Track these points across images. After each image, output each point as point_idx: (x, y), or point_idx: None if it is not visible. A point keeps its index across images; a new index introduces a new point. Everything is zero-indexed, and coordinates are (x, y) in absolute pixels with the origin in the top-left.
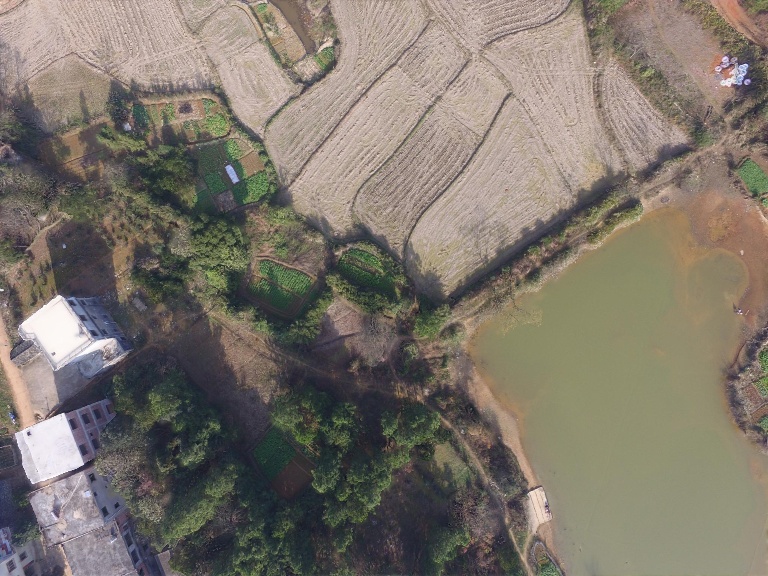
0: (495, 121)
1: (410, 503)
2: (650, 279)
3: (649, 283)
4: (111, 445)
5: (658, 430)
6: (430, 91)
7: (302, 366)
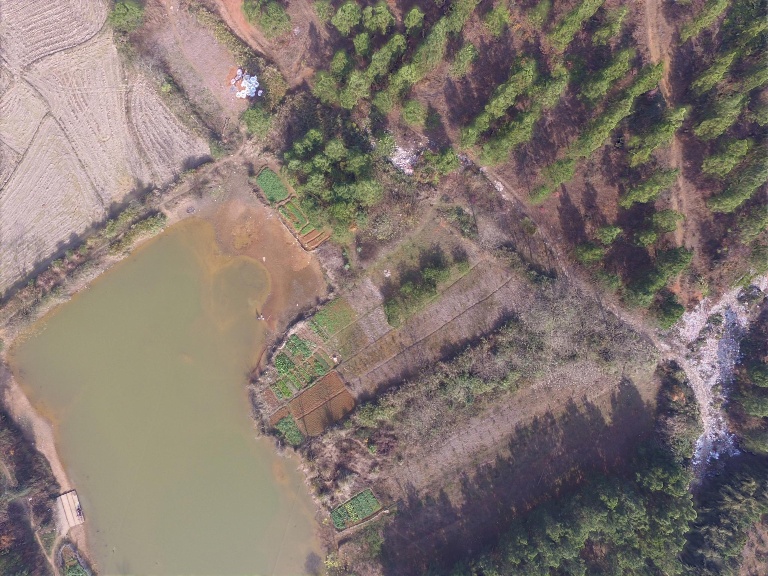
0: (33, 139)
1: None
2: (180, 287)
3: (179, 291)
4: None
5: (186, 434)
6: None
7: None
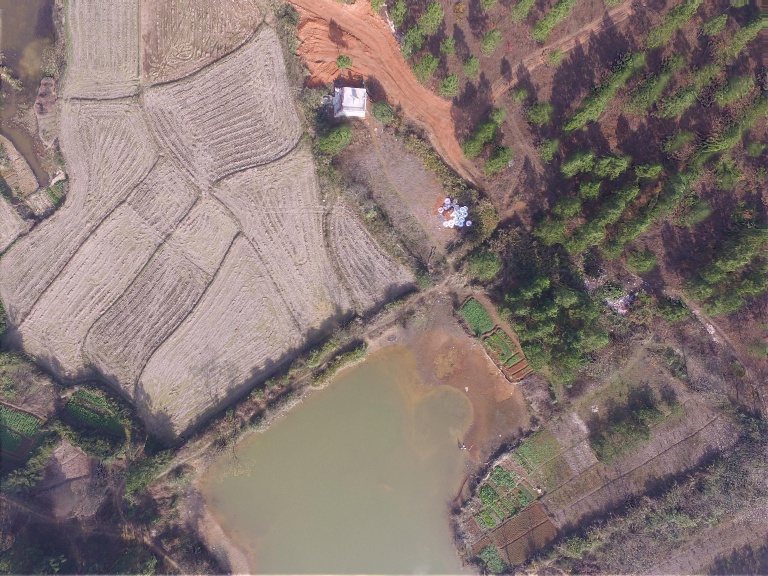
0: (224, 260)
1: None
2: (379, 415)
3: (378, 419)
4: None
5: (385, 561)
6: (160, 229)
7: (26, 512)
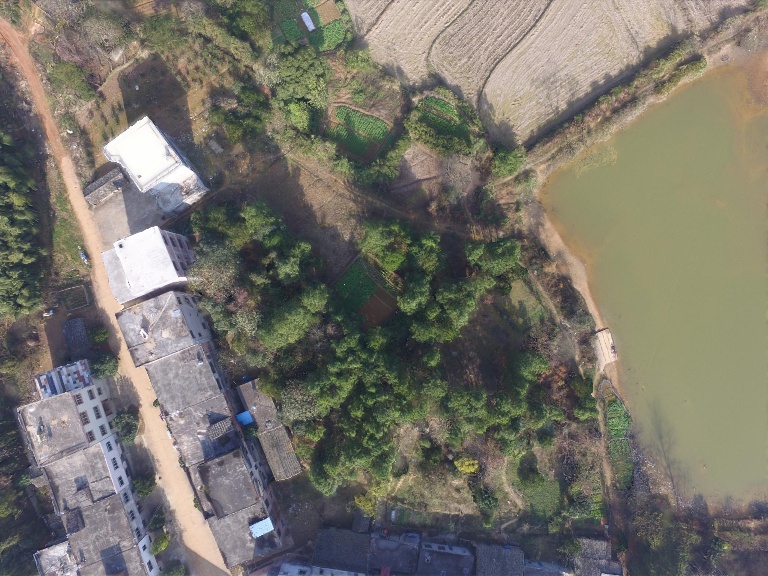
0: None
1: (488, 336)
2: (710, 134)
3: (709, 137)
4: (206, 257)
5: (716, 276)
6: None
7: (381, 206)
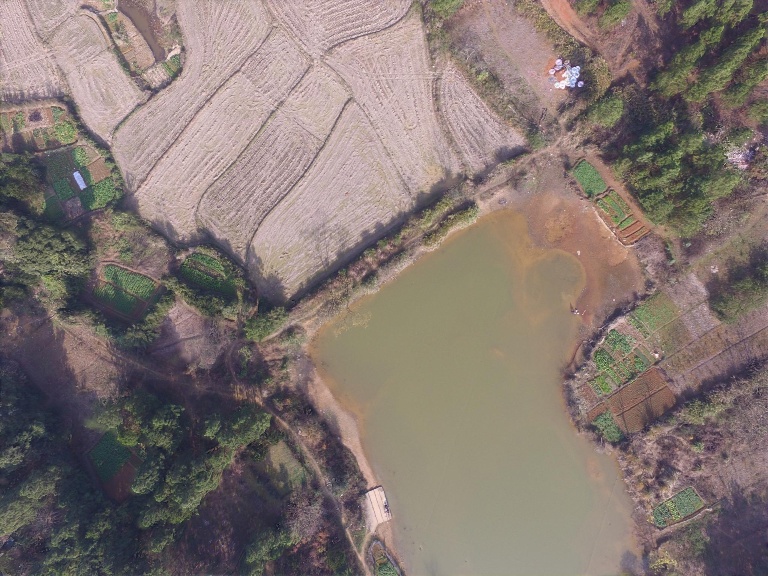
0: (335, 125)
1: (244, 503)
2: (489, 280)
3: (488, 284)
4: None
5: (497, 429)
6: (273, 97)
7: (141, 369)
